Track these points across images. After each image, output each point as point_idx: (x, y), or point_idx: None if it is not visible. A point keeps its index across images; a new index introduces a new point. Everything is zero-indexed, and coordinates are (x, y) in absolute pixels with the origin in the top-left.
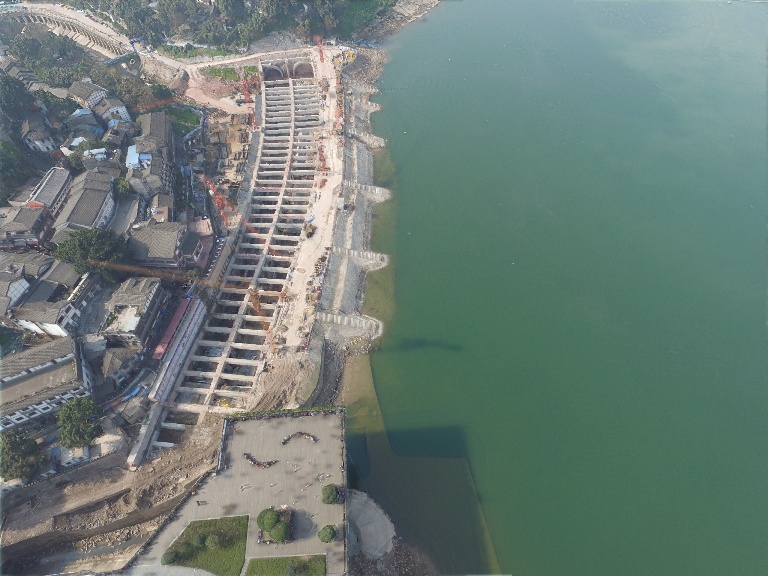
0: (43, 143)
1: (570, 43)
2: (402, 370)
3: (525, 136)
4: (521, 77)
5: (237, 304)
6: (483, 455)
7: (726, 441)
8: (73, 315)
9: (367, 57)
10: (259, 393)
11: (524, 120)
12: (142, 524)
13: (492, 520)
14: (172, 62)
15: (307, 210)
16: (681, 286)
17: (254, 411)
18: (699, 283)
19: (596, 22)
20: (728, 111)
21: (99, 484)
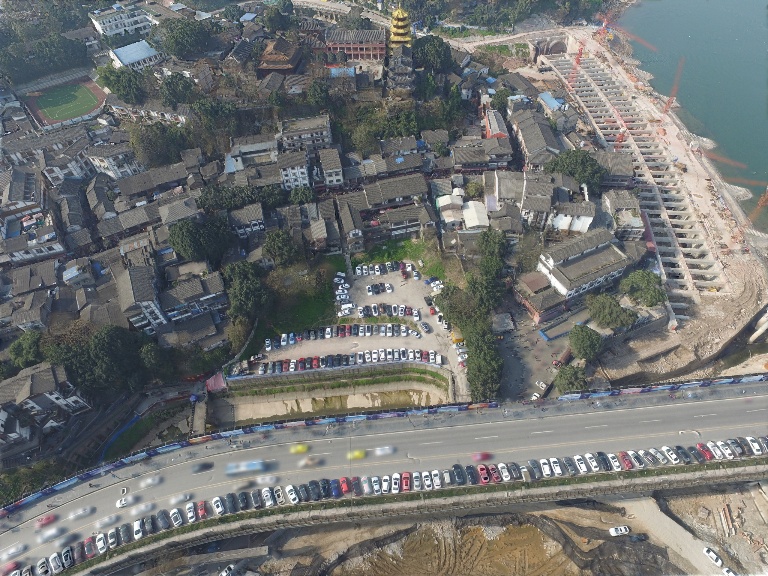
0: (468, 92)
1: None
2: None
3: None
4: (767, 50)
5: (659, 221)
6: None
7: None
8: None
9: None
10: (735, 282)
11: None
12: (685, 376)
13: None
14: (450, 41)
15: (666, 152)
16: None
17: (745, 293)
18: None
19: None
20: None
21: (653, 341)
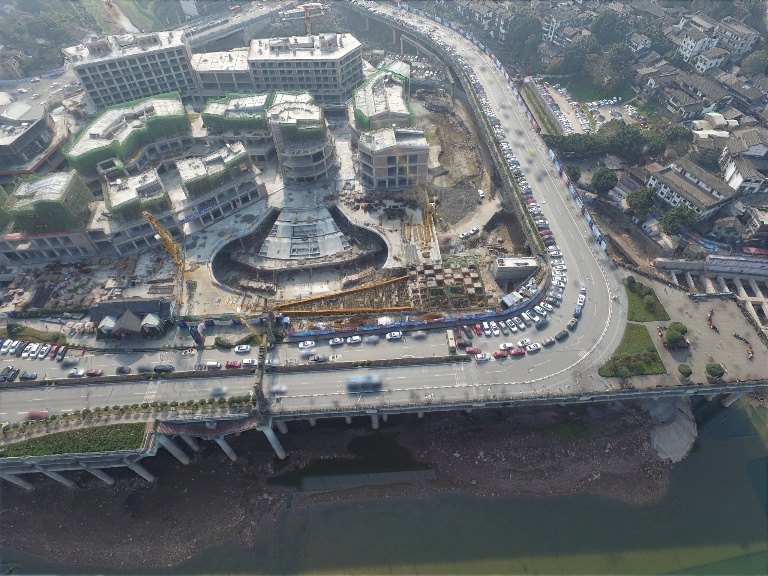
0: None
1: None
2: None
3: None
4: None
5: None
6: None
7: None
8: (753, 187)
9: None
10: None
11: None
12: None
13: (725, 568)
14: None
15: None
16: None
17: None
18: None
19: None
20: None
21: (634, 249)
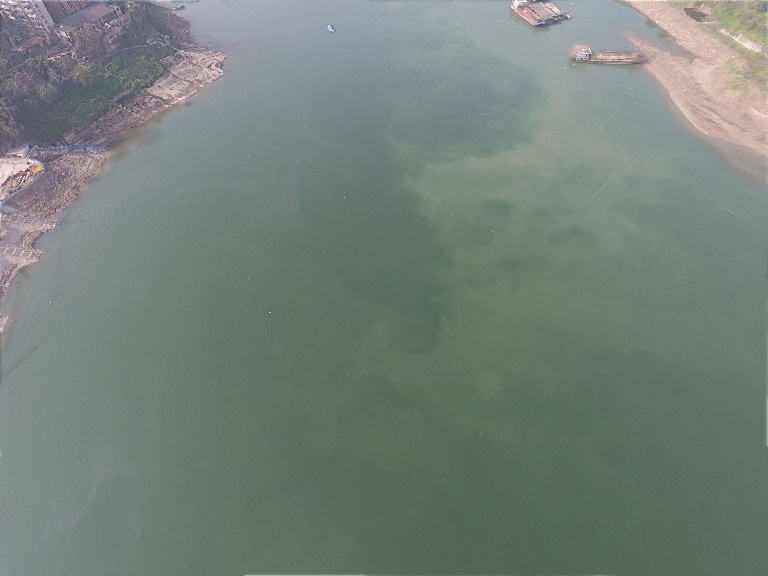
0: None
1: (349, 136)
2: None
3: (212, 304)
4: (260, 195)
5: None
6: None
7: None
8: None
9: (65, 172)
10: None
11: (227, 272)
12: None
13: None
14: None
15: None
16: None
17: None
18: None
19: (396, 102)
20: (505, 249)
21: None
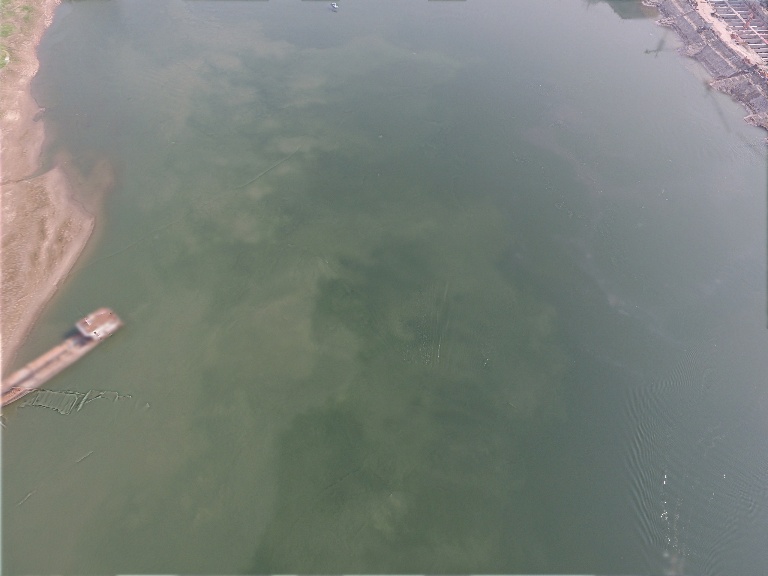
0: None
1: (531, 230)
2: None
3: (584, 94)
4: (599, 164)
5: None
6: None
7: None
8: None
9: None
10: None
11: (586, 111)
12: None
13: None
14: None
15: None
16: (488, 16)
17: None
18: (477, 17)
19: (477, 289)
20: (378, 113)
21: None
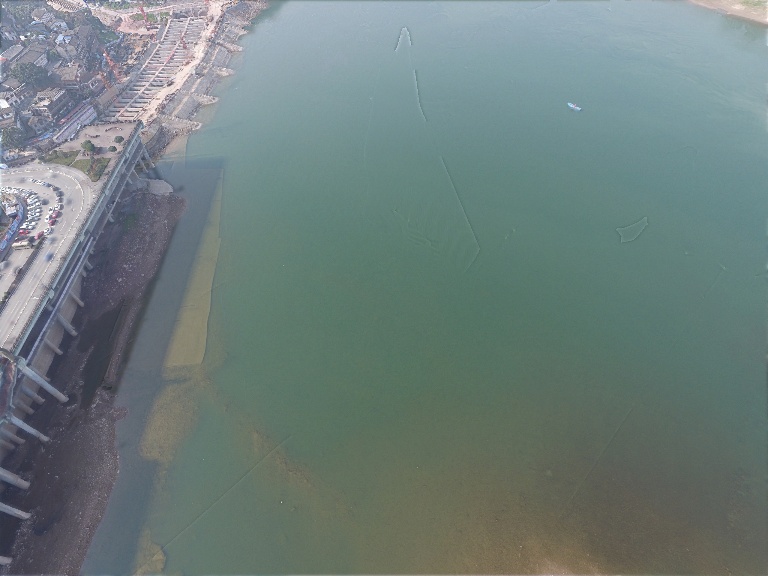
0: (10, 34)
1: None
2: (205, 141)
3: (338, 41)
4: (354, 12)
5: None
6: (233, 167)
7: (344, 137)
8: (15, 101)
9: (249, 5)
10: None
11: (343, 34)
12: None
13: (225, 187)
14: (112, 12)
15: (172, 75)
16: None
17: None
18: None
19: None
20: None
21: None
